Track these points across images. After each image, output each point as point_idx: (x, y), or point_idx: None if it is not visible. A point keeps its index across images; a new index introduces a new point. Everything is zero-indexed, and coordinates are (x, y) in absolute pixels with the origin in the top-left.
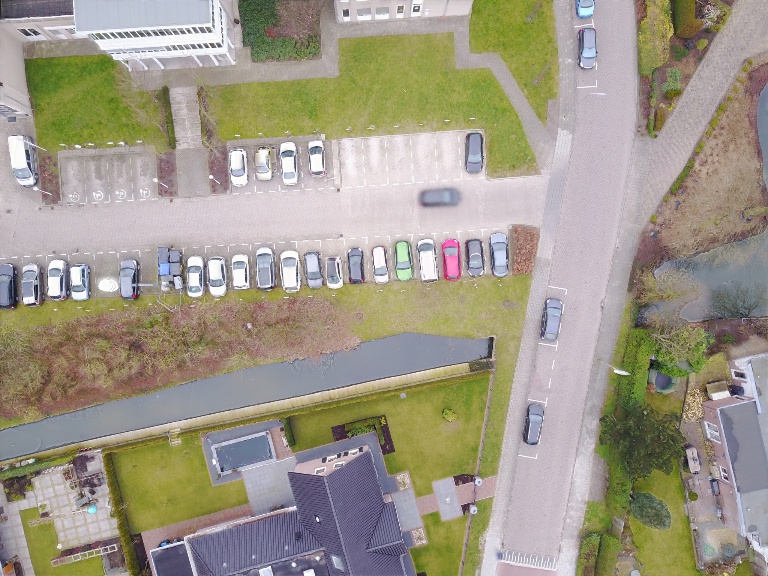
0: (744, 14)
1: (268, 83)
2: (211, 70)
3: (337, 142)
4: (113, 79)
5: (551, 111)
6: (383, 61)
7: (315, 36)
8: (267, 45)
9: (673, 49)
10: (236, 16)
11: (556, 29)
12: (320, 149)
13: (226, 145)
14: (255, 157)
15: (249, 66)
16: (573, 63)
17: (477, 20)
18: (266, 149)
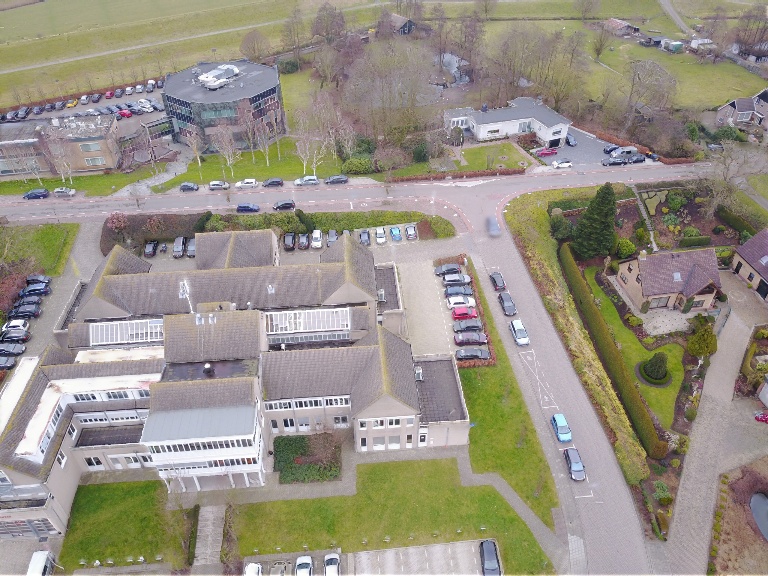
0: (702, 441)
1: (292, 501)
2: (242, 491)
3: (353, 555)
4: (151, 500)
5: (556, 518)
6: (396, 481)
7: (337, 463)
8: (294, 469)
9: (651, 467)
10: (271, 449)
11: (544, 451)
12: (336, 561)
13: (243, 561)
14: (270, 572)
15: (276, 487)
16: (566, 477)
17: (475, 448)
18: (282, 564)
